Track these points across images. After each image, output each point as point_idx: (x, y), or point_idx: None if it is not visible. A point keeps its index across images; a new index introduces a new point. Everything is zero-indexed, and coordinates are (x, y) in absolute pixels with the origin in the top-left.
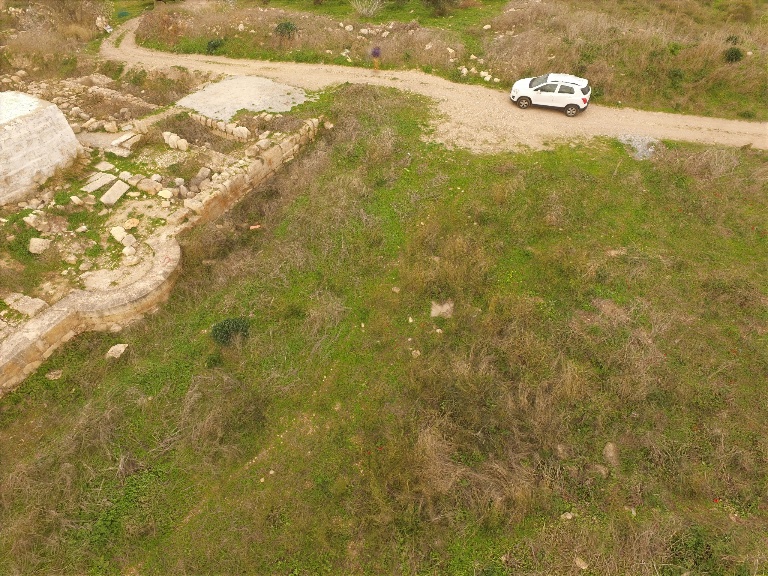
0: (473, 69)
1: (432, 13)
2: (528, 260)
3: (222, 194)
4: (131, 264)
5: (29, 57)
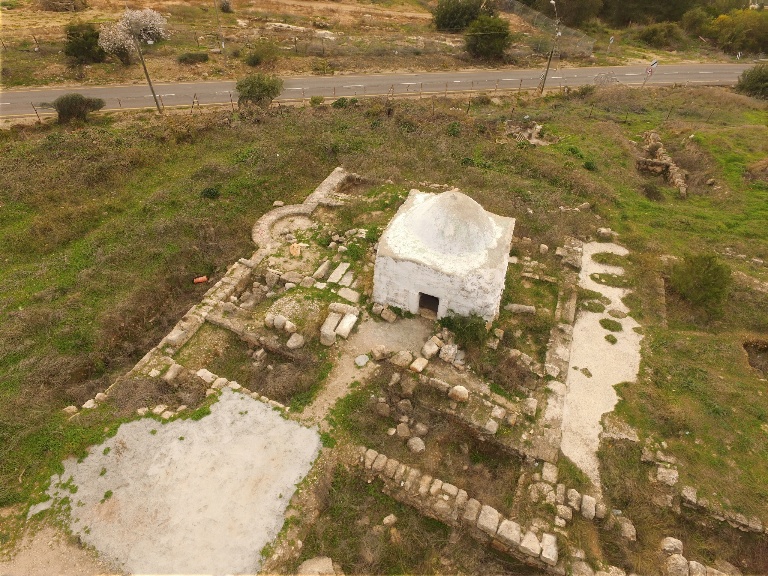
0: None
1: None
2: None
3: None
4: None
5: None
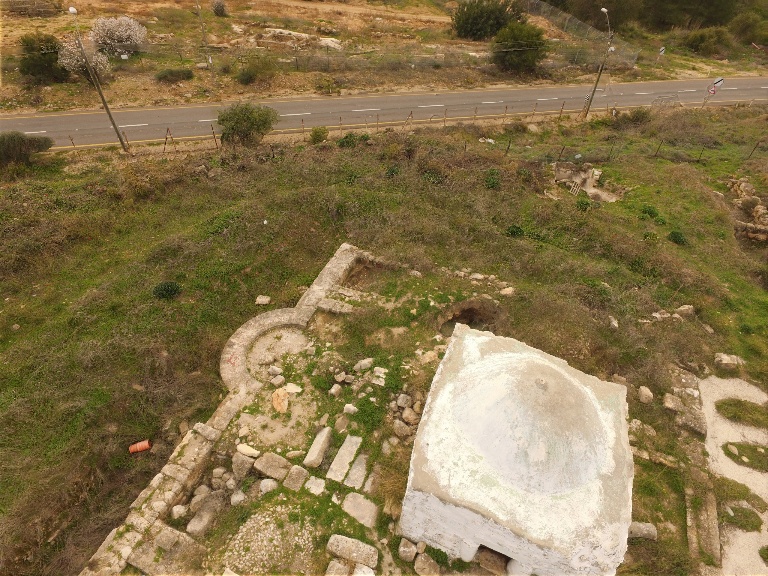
0: None
1: None
2: None
3: None
4: None
5: None
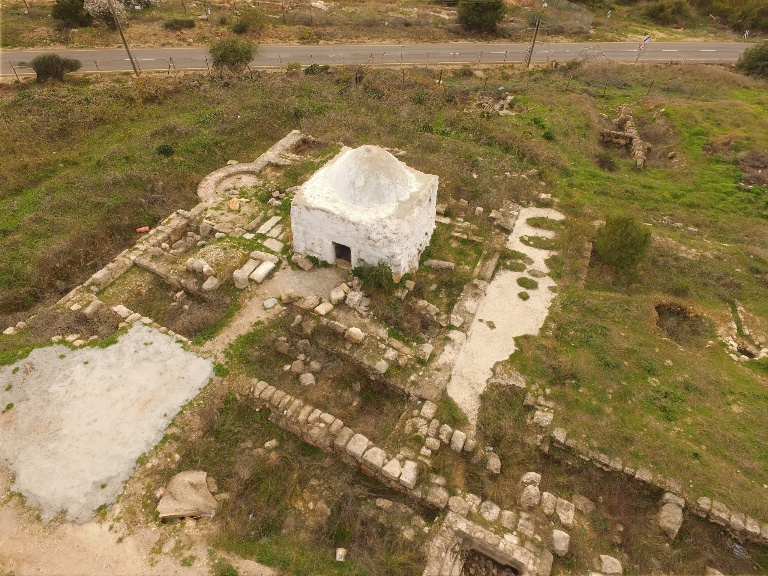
0: None
1: None
2: None
3: None
4: None
5: None
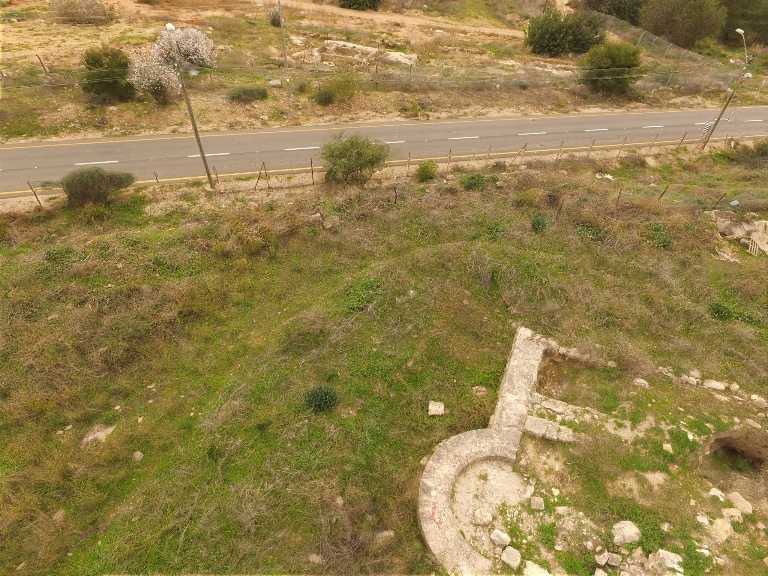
0: None
1: None
2: None
3: None
4: None
5: None
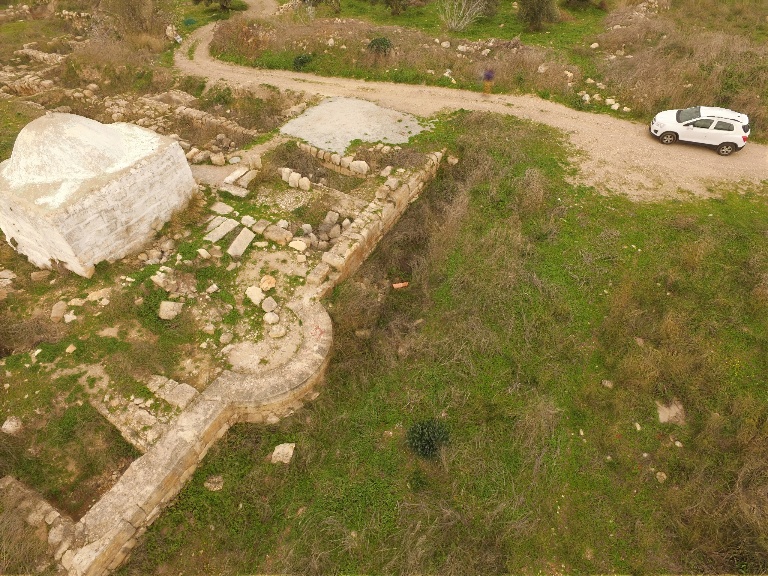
0: (597, 96)
1: (526, 28)
2: (750, 345)
3: (360, 246)
4: (278, 336)
5: (99, 69)
